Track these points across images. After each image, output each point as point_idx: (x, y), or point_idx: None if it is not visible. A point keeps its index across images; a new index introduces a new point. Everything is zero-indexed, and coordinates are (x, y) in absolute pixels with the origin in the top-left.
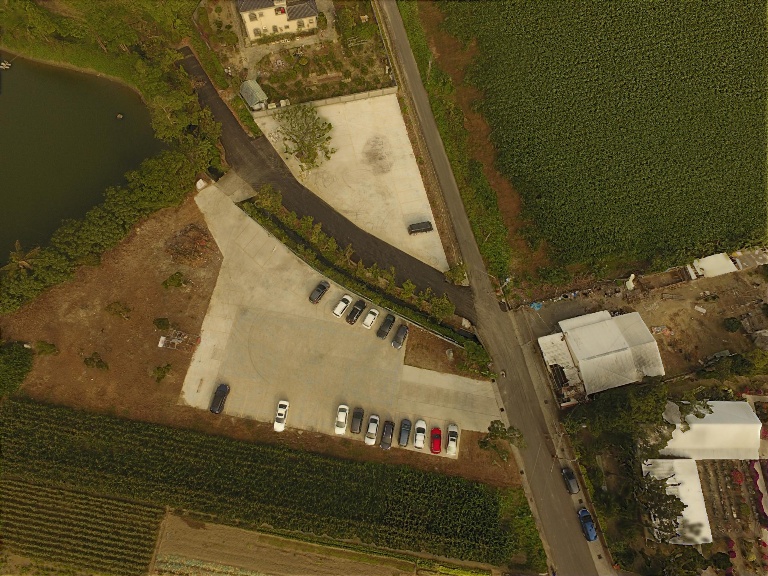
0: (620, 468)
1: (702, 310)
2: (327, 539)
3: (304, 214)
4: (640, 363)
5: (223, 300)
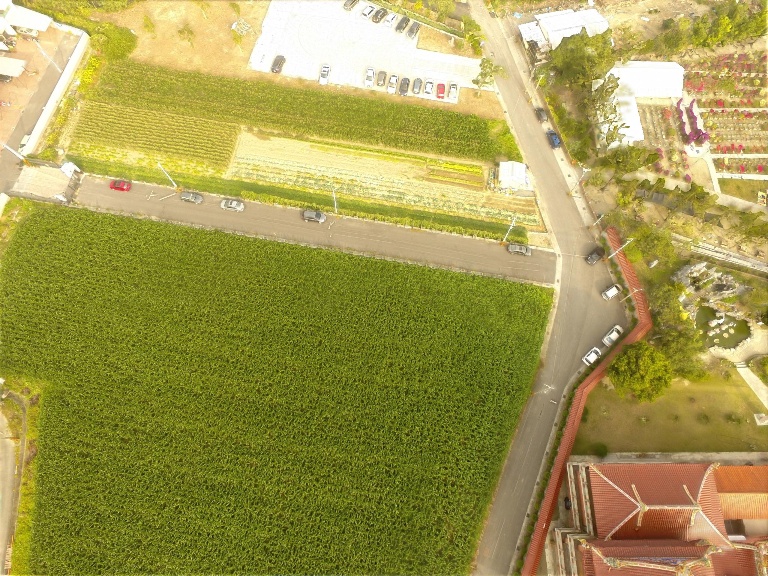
0: (579, 106)
1: (647, 19)
2: (360, 146)
3: None
4: None
5: (278, 9)
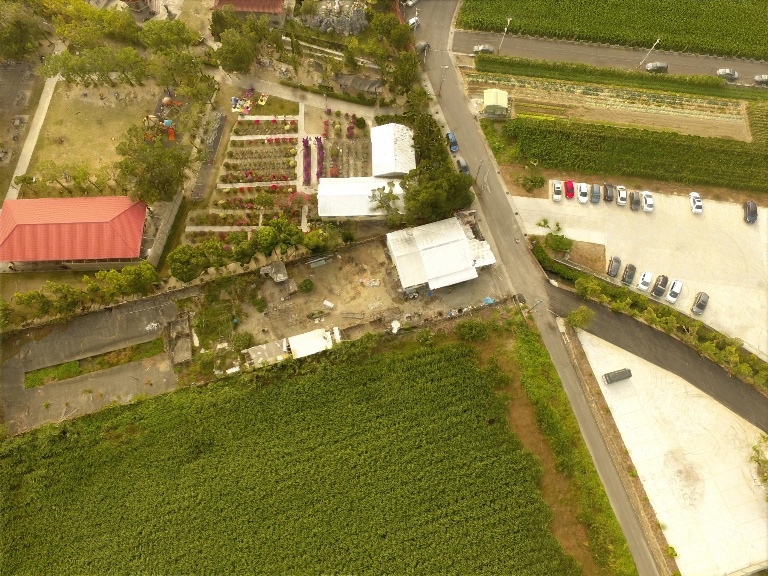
0: None
1: (327, 303)
2: None
3: (744, 390)
4: (410, 240)
5: None
